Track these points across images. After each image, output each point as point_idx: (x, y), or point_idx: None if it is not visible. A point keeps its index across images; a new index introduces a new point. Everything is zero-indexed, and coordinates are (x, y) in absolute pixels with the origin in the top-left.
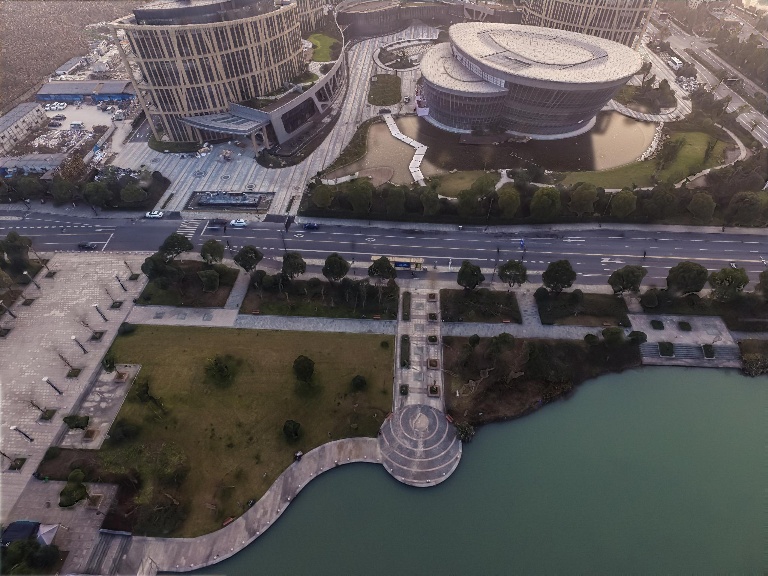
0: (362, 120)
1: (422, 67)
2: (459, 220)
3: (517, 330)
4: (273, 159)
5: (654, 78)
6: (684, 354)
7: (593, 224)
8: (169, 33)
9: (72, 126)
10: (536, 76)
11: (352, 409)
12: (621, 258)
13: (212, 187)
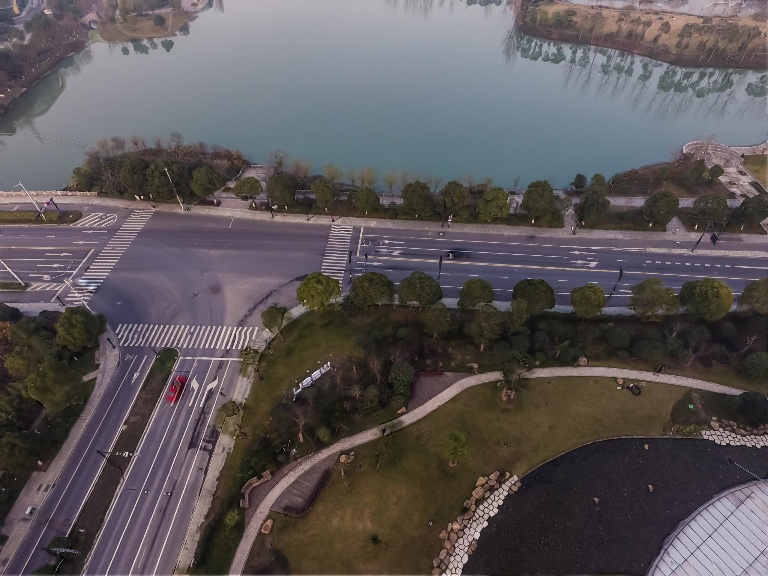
0: None
1: None
2: None
3: None
4: None
5: None
6: None
7: None
8: None
9: None
10: None
11: None
12: (575, 266)
13: None
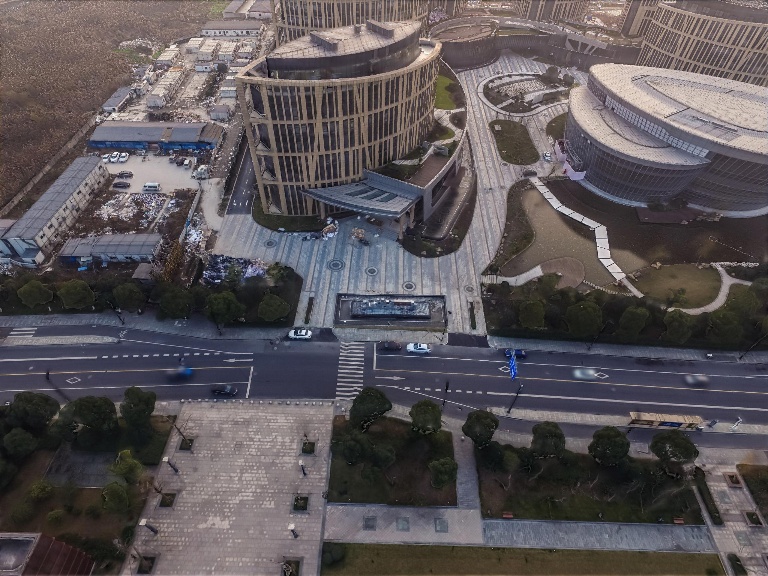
0: (507, 185)
1: (581, 123)
2: (704, 345)
3: None
4: (428, 246)
5: None
6: None
7: None
8: (315, 90)
9: (146, 188)
10: (760, 150)
11: None
12: None
13: (359, 287)
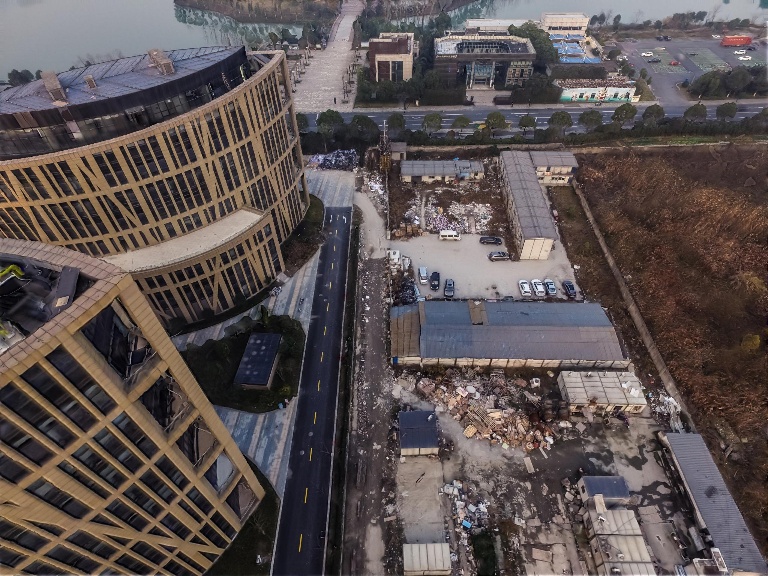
0: None
1: None
2: None
3: None
4: None
5: None
6: None
7: None
8: None
9: None
10: None
11: None
12: None
13: None
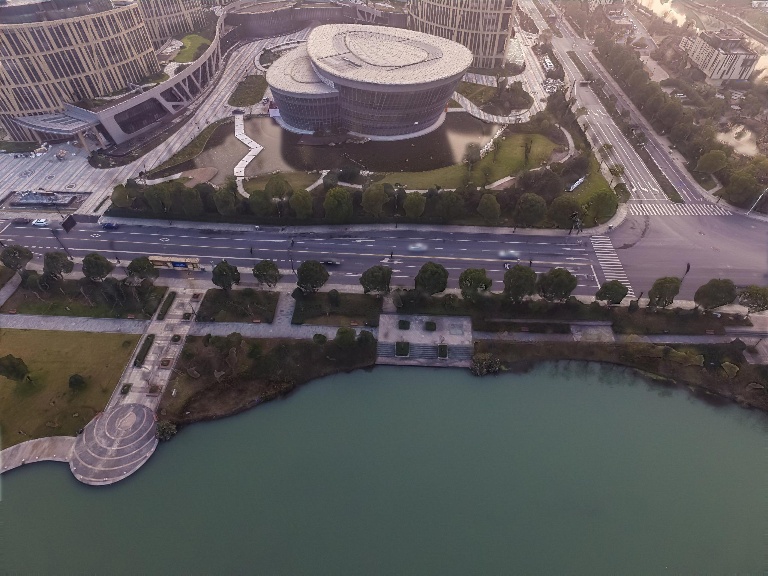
0: (212, 121)
1: (270, 68)
2: (258, 220)
3: (264, 330)
4: (101, 159)
5: (506, 80)
6: (419, 354)
7: (390, 225)
8: None
9: None
10: (356, 77)
11: (64, 408)
12: (401, 258)
13: (32, 187)
